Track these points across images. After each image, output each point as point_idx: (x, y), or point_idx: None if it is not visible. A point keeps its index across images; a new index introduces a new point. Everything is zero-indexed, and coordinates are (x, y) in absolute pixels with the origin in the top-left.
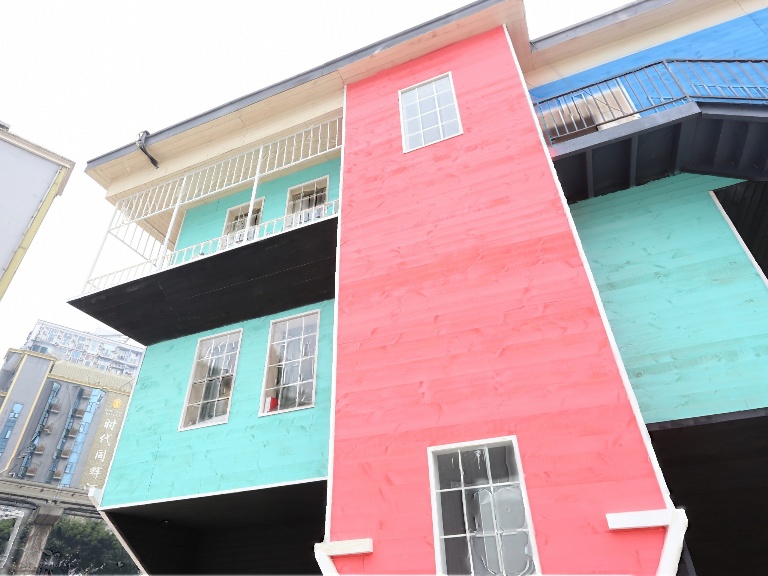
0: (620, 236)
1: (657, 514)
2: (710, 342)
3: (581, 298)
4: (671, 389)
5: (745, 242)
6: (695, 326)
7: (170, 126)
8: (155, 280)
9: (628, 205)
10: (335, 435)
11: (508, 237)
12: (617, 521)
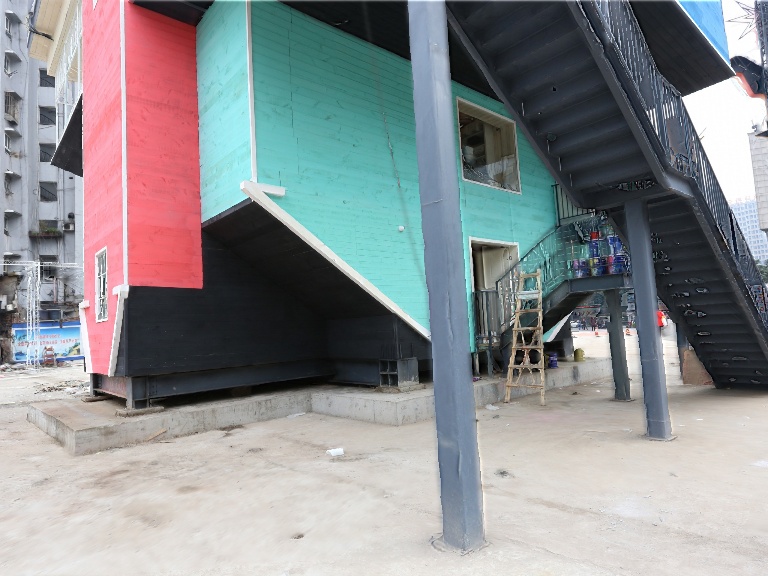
0: (211, 54)
1: (117, 288)
2: (227, 154)
3: (120, 148)
4: (213, 195)
5: (363, 1)
6: (225, 141)
7: (35, 3)
8: (66, 144)
9: (217, 16)
10: (84, 248)
11: (110, 96)
12: (113, 291)
